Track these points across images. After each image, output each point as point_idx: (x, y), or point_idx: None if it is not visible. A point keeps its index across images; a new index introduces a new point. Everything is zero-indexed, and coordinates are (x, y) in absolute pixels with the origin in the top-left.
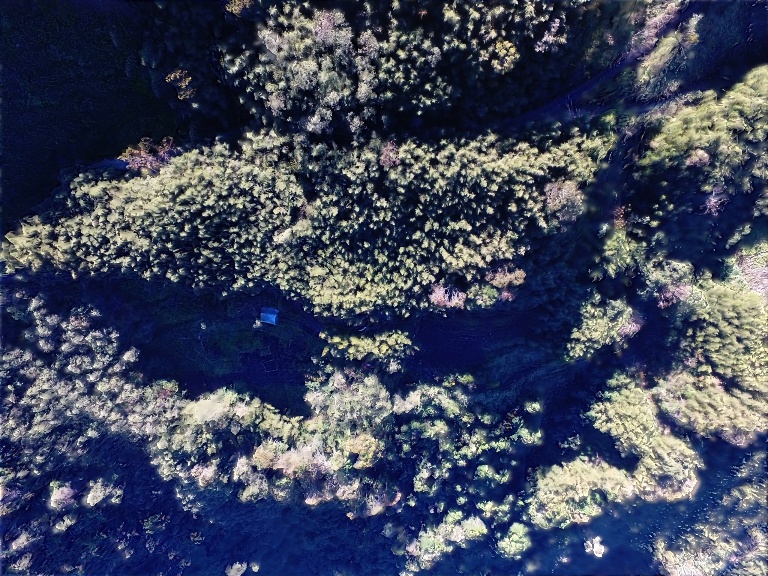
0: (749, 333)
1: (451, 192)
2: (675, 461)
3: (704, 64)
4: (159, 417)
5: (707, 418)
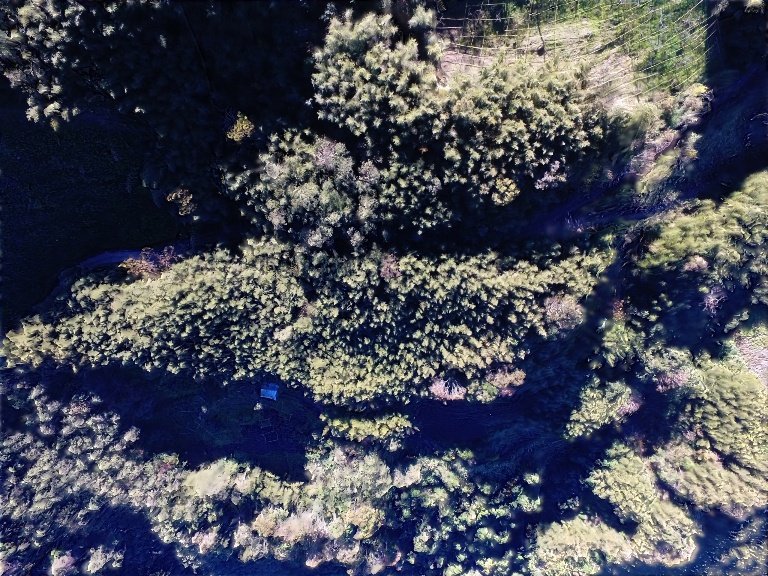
0: (747, 414)
1: (451, 301)
2: (674, 529)
3: (702, 172)
4: (160, 490)
5: (705, 493)
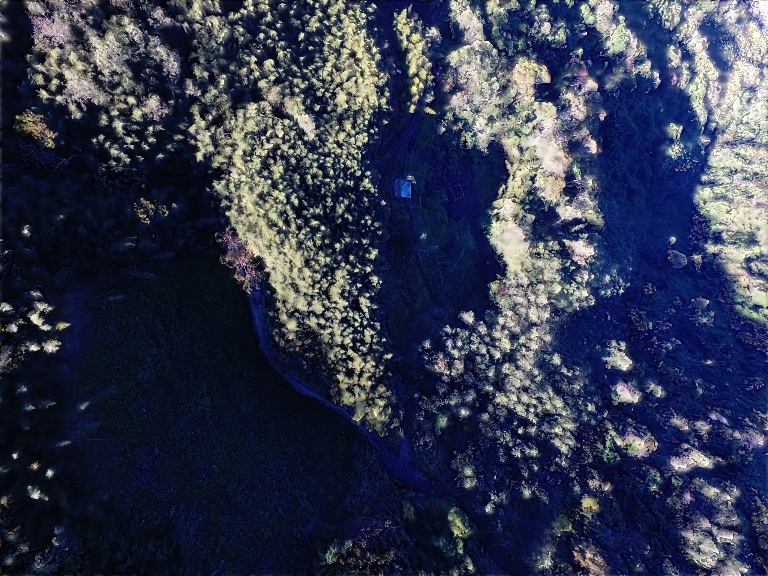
0: None
1: None
2: None
3: None
4: None
5: None
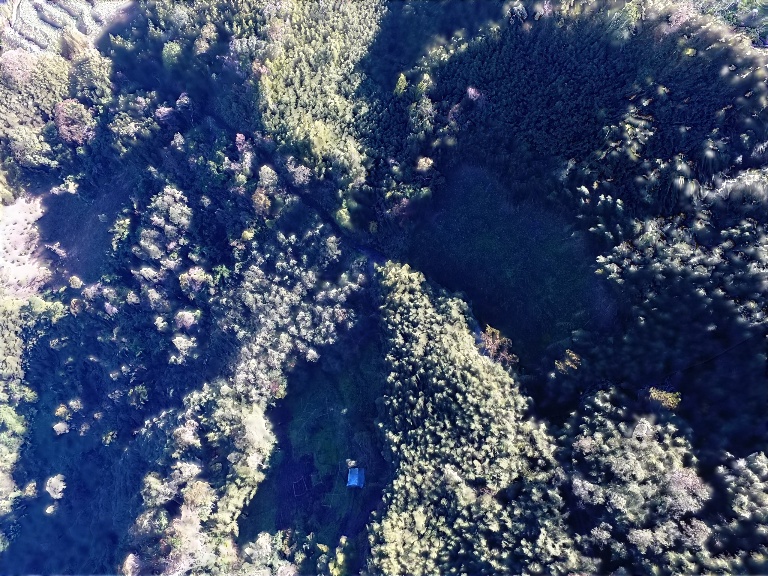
0: None
1: None
2: None
3: None
4: (252, 384)
5: None
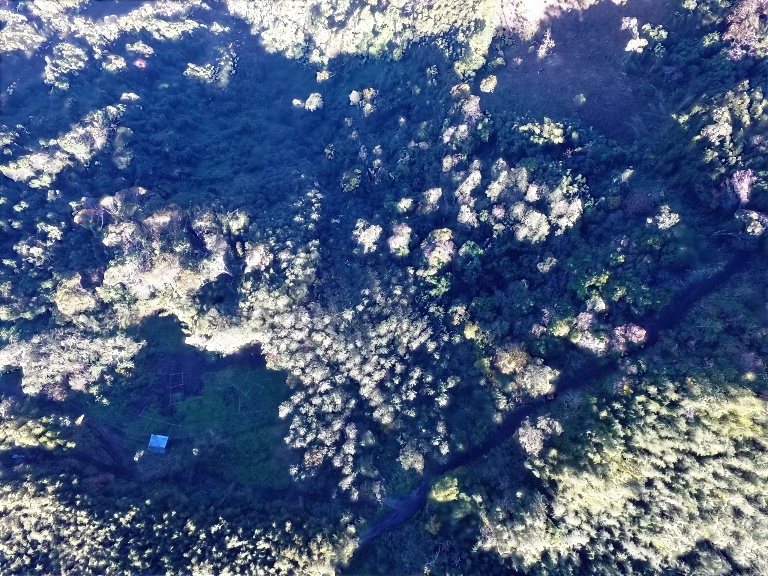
0: None
1: None
2: None
3: None
4: None
5: None
